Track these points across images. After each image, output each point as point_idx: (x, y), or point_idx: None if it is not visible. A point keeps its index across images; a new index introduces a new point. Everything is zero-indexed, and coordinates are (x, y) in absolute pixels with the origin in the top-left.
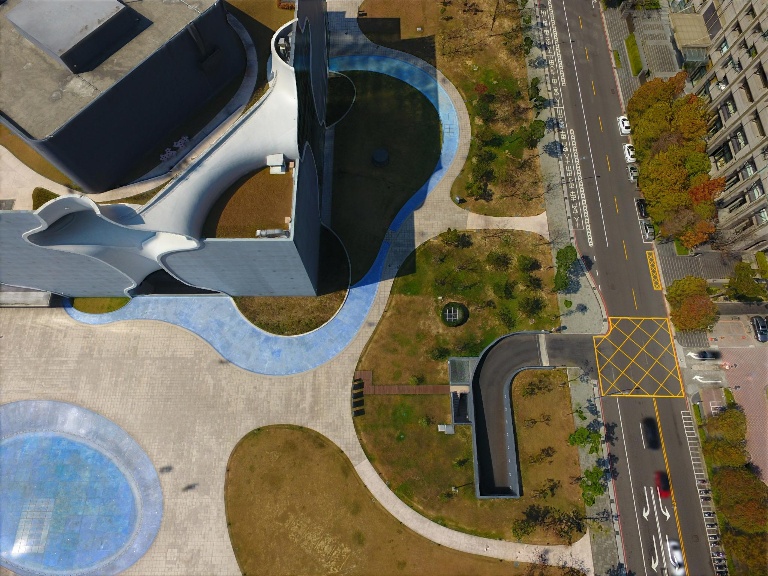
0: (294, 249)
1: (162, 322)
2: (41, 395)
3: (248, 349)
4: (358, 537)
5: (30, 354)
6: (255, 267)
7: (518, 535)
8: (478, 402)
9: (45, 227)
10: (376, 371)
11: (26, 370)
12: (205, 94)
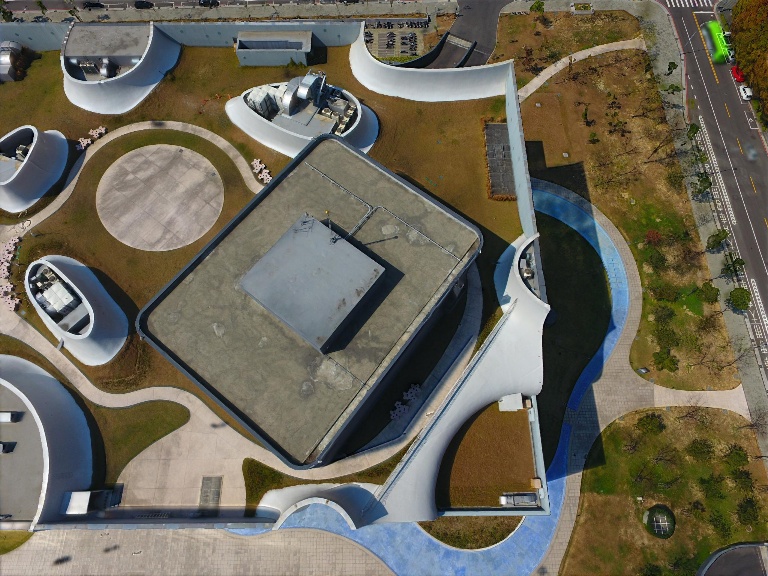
0: None
1: (324, 532)
2: None
3: (427, 567)
4: None
5: (175, 575)
6: None
7: None
8: None
9: None
10: None
11: None
12: (431, 325)
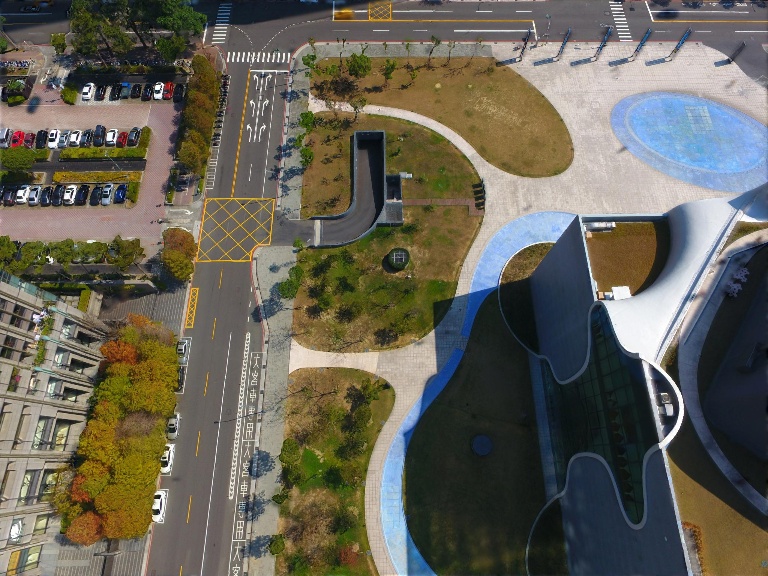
0: None
1: None
2: None
3: None
4: (469, 114)
5: None
6: None
7: (363, 98)
8: (378, 198)
9: None
10: (466, 216)
11: None
12: None
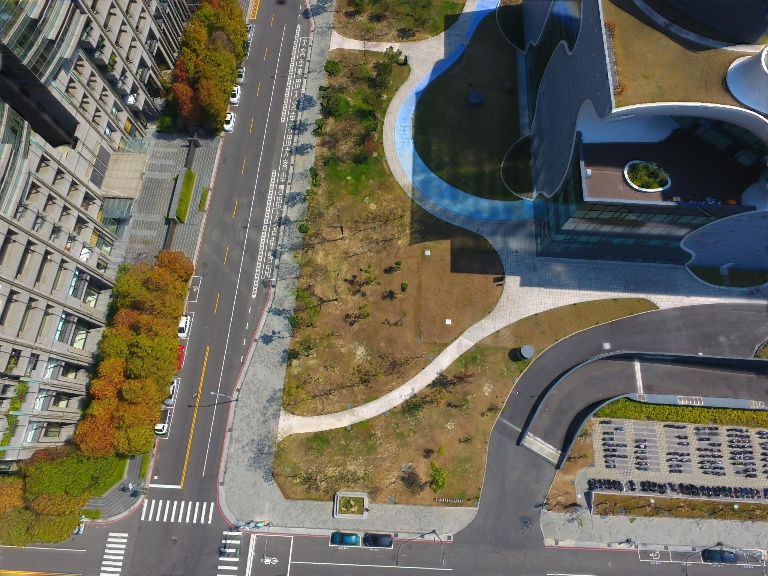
0: None
1: None
2: None
3: None
4: None
5: None
6: None
7: None
8: None
9: None
10: None
11: None
12: None
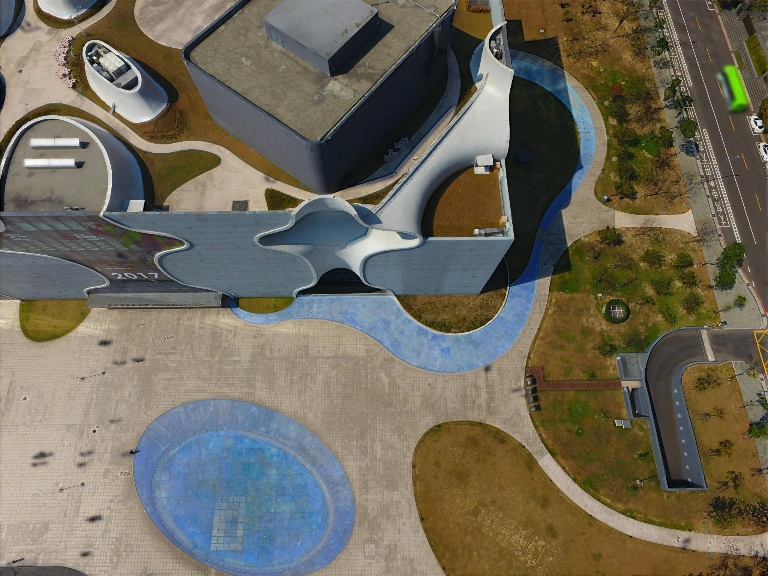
0: (506, 247)
1: (329, 321)
2: (219, 394)
3: (417, 347)
4: (551, 530)
5: (203, 354)
6: (449, 266)
7: (723, 525)
8: None
9: (289, 227)
10: (546, 367)
11: (201, 370)
12: (417, 96)
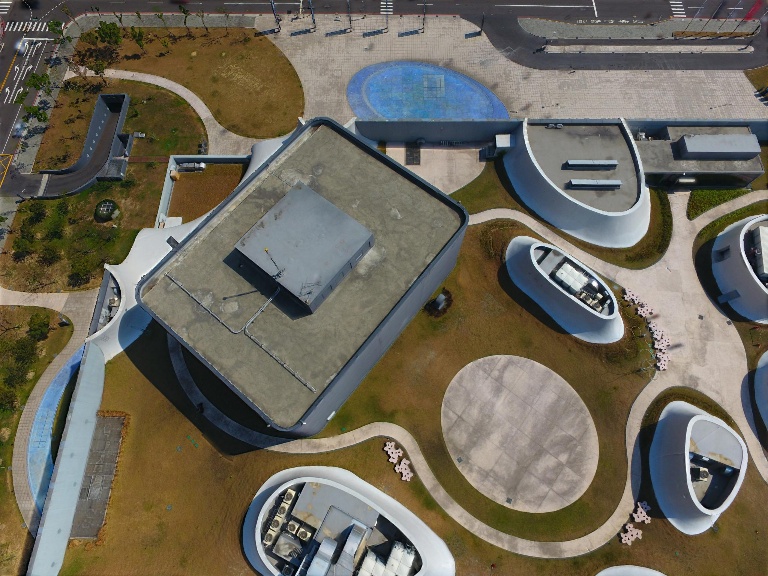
0: None
1: None
2: None
3: None
4: (215, 80)
5: None
6: None
7: (100, 62)
8: None
9: None
10: None
11: None
12: None
